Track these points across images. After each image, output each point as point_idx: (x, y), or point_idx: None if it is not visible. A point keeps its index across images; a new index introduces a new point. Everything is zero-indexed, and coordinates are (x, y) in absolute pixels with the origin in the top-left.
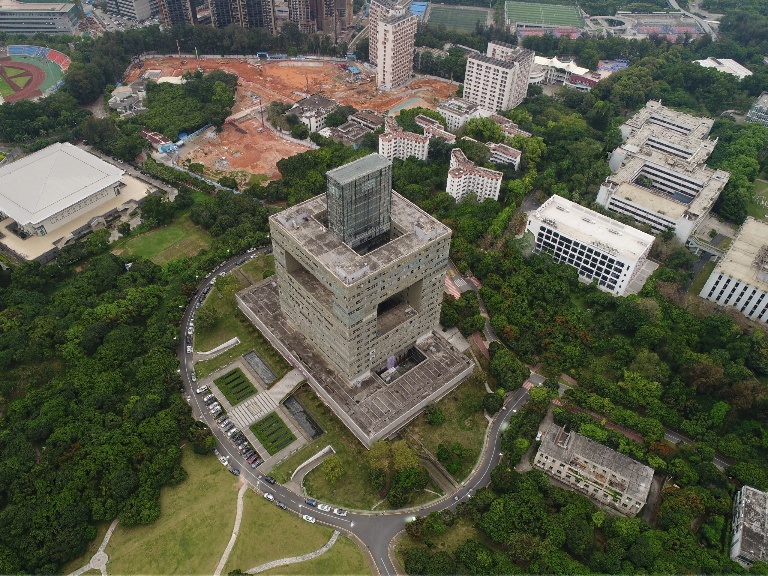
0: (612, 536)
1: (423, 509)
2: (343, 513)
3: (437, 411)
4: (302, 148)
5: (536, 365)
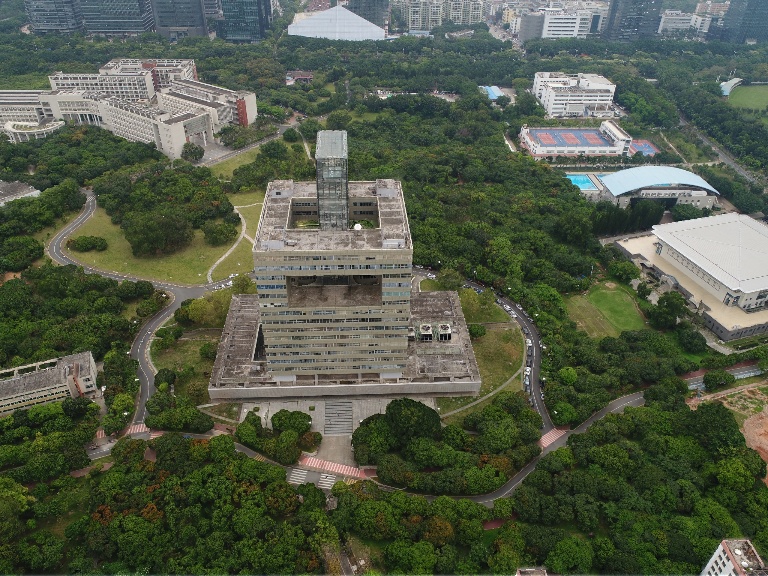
0: (3, 365)
1: (168, 316)
2: (217, 286)
3: (208, 347)
4: None
5: (150, 453)
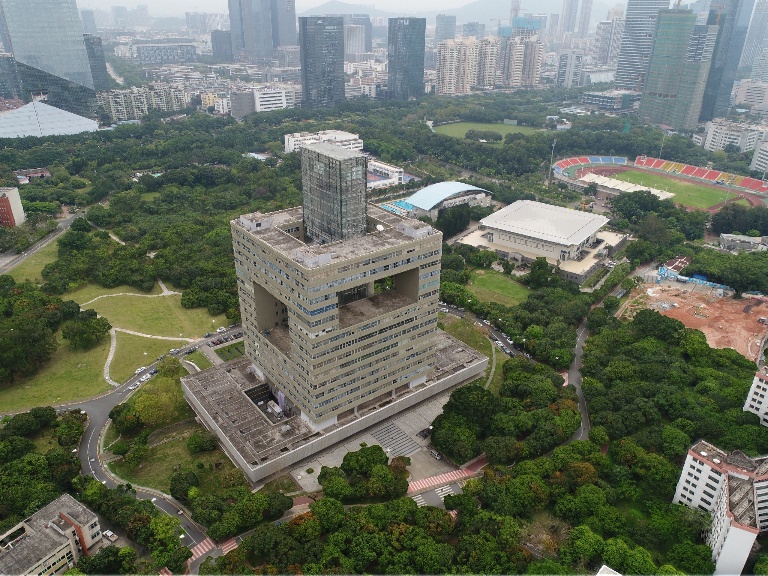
0: None
1: (100, 435)
2: (132, 386)
3: (199, 438)
4: (751, 355)
5: None
